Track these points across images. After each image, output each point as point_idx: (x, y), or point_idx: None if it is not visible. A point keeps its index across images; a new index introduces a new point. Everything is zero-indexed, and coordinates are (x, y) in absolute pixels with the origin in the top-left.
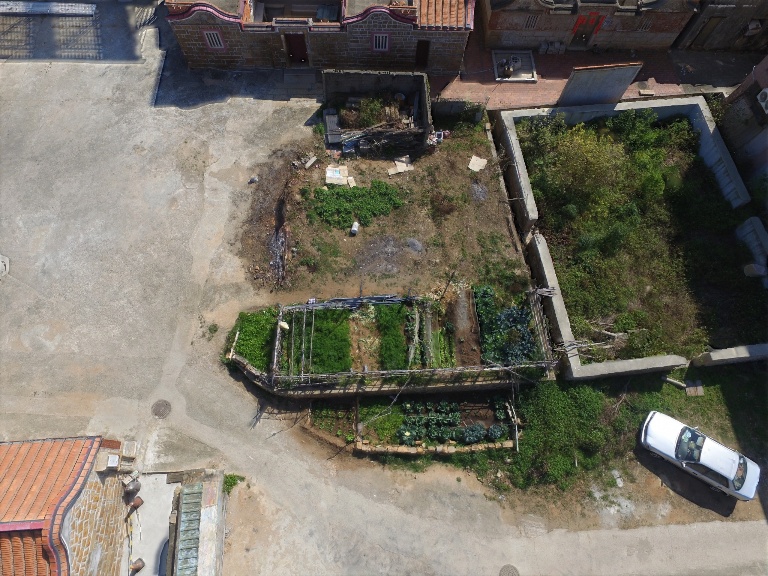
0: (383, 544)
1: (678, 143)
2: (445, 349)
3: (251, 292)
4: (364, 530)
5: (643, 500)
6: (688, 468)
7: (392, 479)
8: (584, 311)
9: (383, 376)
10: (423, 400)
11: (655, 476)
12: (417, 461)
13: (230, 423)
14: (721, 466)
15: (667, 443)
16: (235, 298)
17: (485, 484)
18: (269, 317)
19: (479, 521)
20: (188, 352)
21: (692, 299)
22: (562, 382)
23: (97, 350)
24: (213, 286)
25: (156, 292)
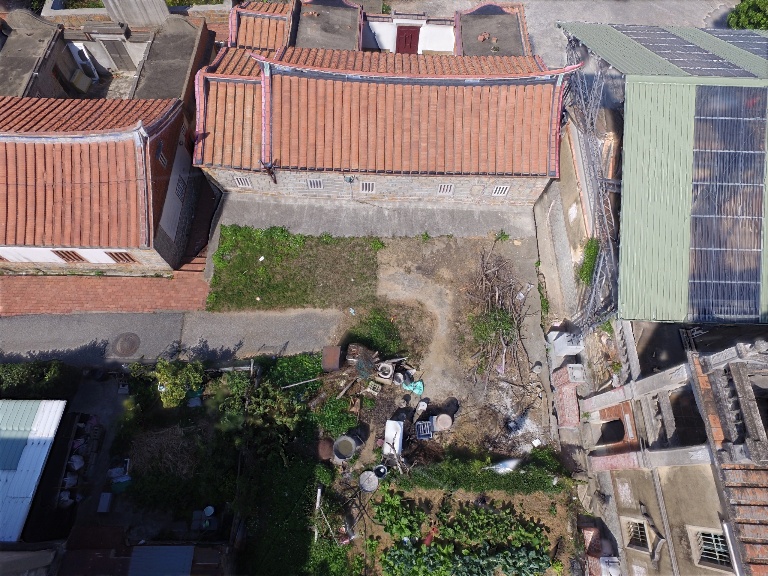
0: None
1: (85, 3)
2: None
3: None
4: None
5: None
6: None
7: None
8: None
9: None
10: None
11: None
12: None
13: None
14: None
15: None
16: None
17: None
18: None
19: None
20: None
21: None
22: None
23: None
24: None
25: None
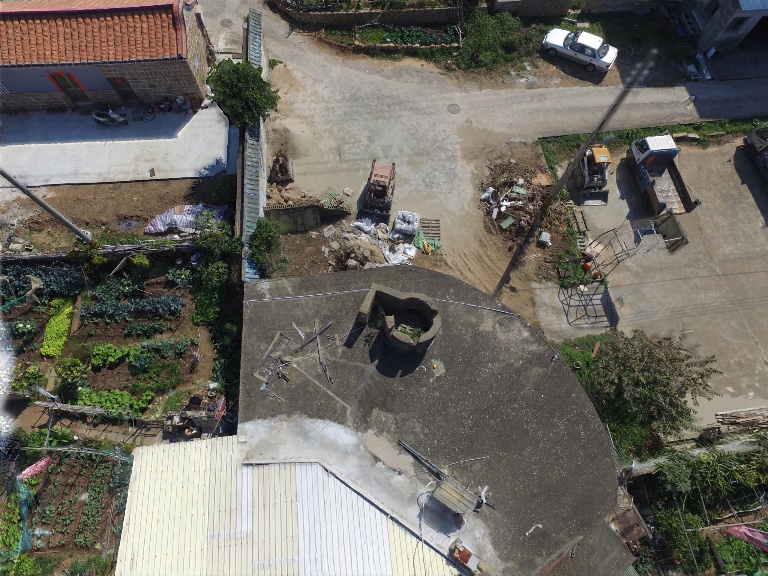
0: (373, 93)
1: None
2: None
3: None
4: (361, 86)
5: (543, 77)
6: (572, 52)
7: (379, 64)
8: None
9: (372, 1)
10: None
11: (552, 65)
12: (395, 55)
13: (271, 34)
14: (591, 43)
15: (559, 39)
16: None
17: (440, 68)
18: None
19: (435, 84)
20: None
21: None
22: None
23: None
24: None
25: None
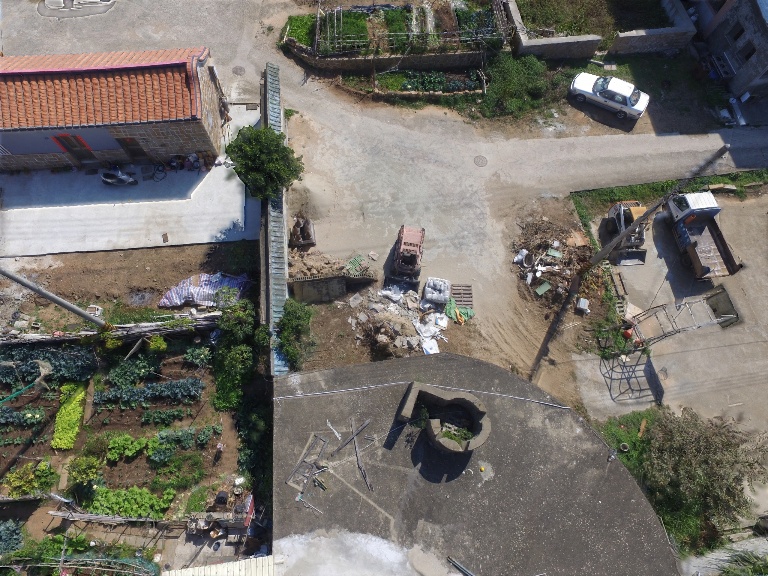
0: (395, 145)
1: None
2: (434, 34)
3: (295, 7)
4: (382, 138)
5: (572, 124)
6: (601, 99)
7: (400, 113)
8: (533, 21)
9: (392, 46)
10: (420, 72)
11: (580, 112)
12: (417, 103)
13: (286, 82)
14: (622, 90)
15: (587, 85)
16: (284, 11)
17: (464, 116)
18: (310, 18)
19: (460, 134)
20: (254, 41)
21: (610, 16)
22: (516, 56)
23: (190, 39)
24: (268, 4)
25: (228, 8)
